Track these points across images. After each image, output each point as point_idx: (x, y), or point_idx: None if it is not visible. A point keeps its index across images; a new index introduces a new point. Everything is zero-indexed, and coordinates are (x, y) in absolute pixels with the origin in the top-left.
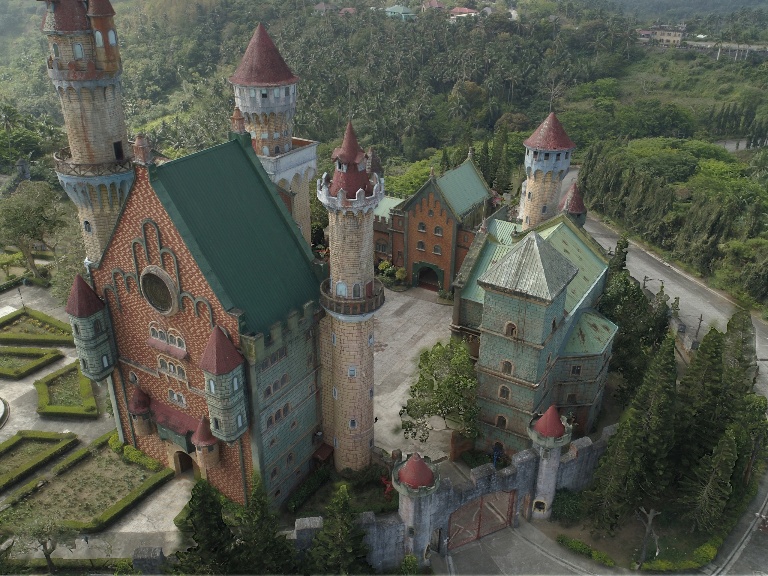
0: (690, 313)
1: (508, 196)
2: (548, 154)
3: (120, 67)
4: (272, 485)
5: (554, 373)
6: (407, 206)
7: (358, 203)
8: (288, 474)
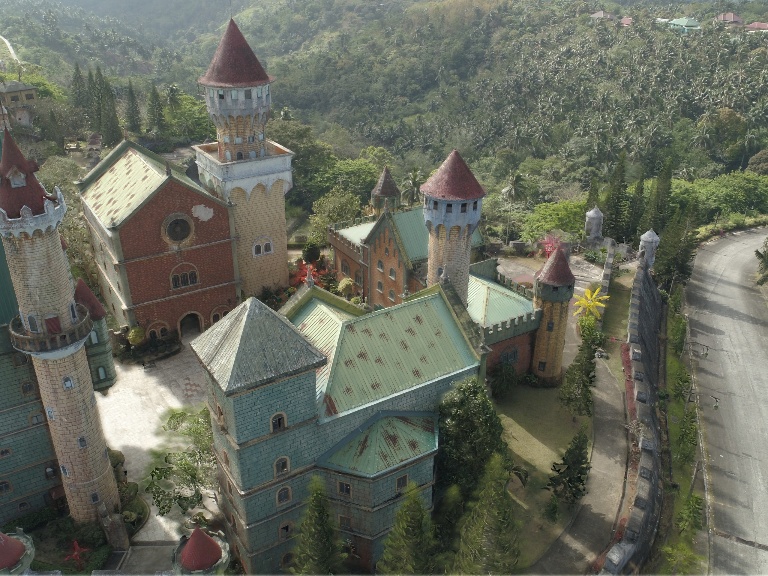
0: (754, 453)
1: (624, 248)
2: (437, 202)
3: None
4: None
5: (316, 483)
6: (369, 238)
7: None
8: (2, 502)
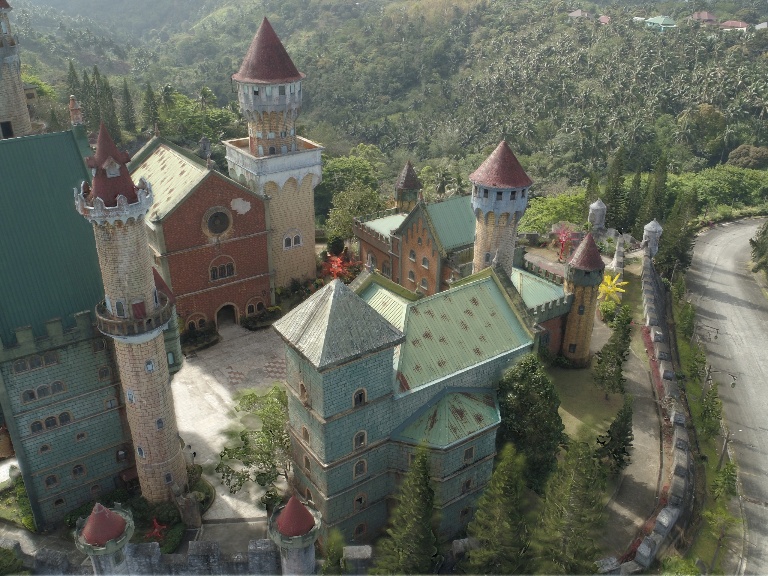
0: None
1: (628, 238)
2: (487, 190)
3: (8, 49)
4: (49, 492)
5: (388, 457)
6: (400, 229)
7: (95, 212)
8: (76, 485)
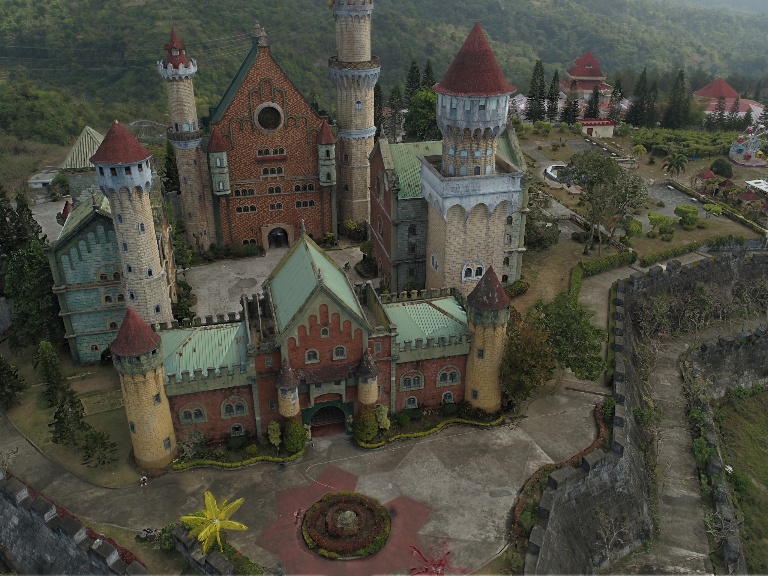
0: None
1: None
2: None
3: (338, 6)
4: None
5: None
6: None
7: None
8: None
